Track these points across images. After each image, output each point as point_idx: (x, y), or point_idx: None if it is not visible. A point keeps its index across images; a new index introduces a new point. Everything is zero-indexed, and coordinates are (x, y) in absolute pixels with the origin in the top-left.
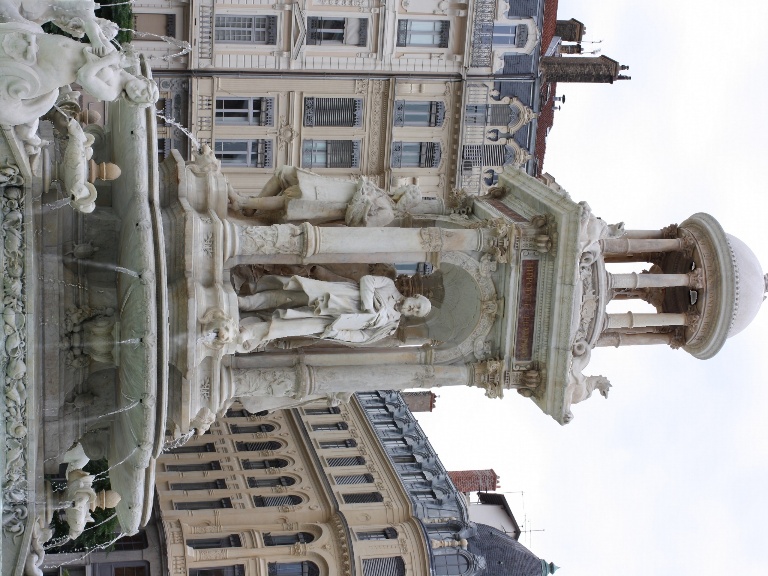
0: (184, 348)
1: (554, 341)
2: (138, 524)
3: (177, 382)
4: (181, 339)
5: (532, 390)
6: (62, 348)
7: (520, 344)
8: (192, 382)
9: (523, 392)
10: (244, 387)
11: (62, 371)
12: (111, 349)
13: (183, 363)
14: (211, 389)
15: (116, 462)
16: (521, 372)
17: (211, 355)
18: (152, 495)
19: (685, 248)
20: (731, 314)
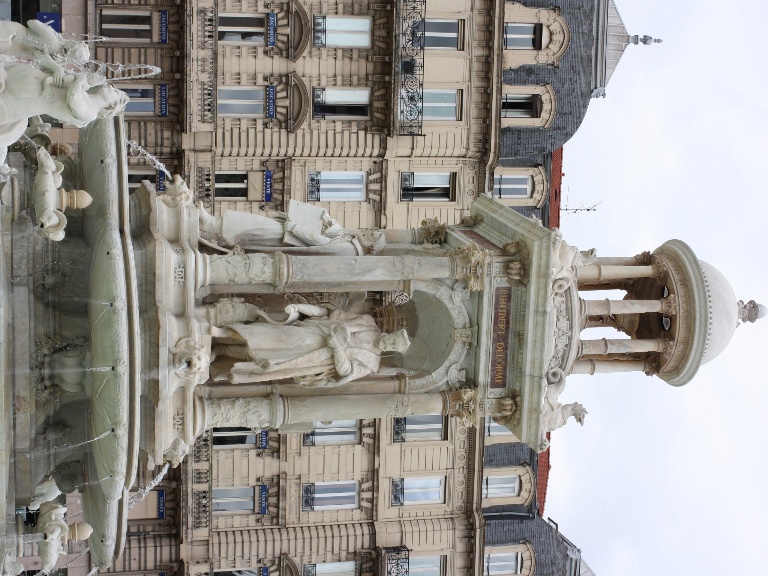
0: None
1: None
2: (123, 290)
3: None
4: None
5: (518, 259)
6: (26, 163)
7: None
8: None
9: (511, 263)
10: None
11: None
12: None
13: (145, 197)
14: None
15: None
16: (498, 251)
17: (174, 218)
18: (133, 261)
19: (627, 278)
20: (683, 244)
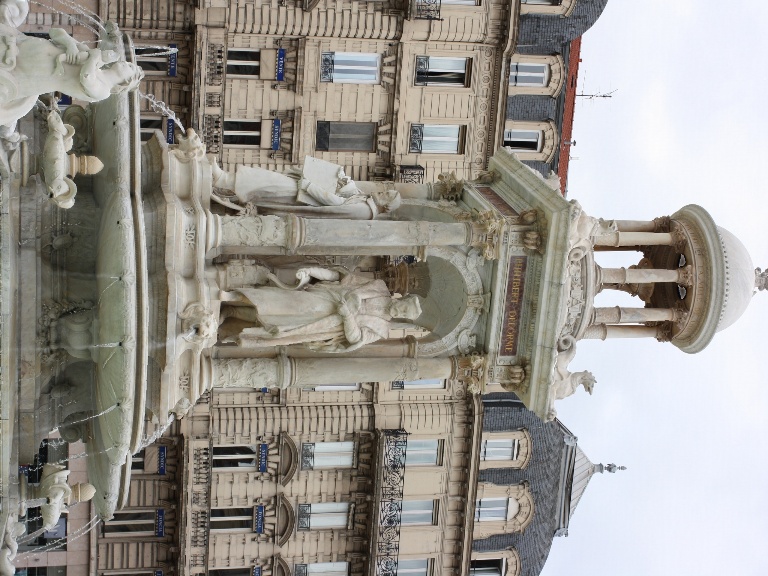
0: (156, 147)
1: (529, 189)
2: (132, 262)
3: (157, 195)
4: (153, 148)
5: (536, 229)
6: (36, 113)
7: (503, 211)
8: (173, 199)
9: (528, 233)
10: (230, 217)
11: (37, 124)
12: (83, 113)
13: (157, 153)
14: (194, 208)
15: (102, 248)
16: None
17: (187, 174)
18: (143, 230)
19: None
20: (704, 211)
